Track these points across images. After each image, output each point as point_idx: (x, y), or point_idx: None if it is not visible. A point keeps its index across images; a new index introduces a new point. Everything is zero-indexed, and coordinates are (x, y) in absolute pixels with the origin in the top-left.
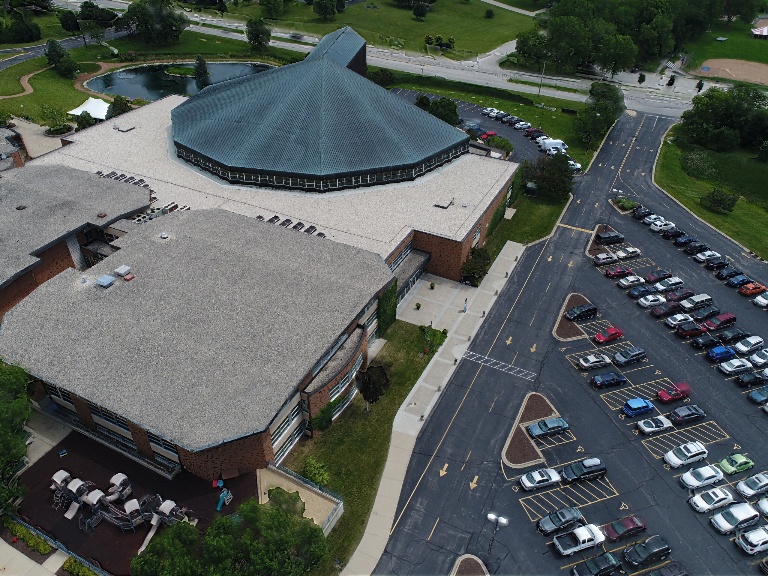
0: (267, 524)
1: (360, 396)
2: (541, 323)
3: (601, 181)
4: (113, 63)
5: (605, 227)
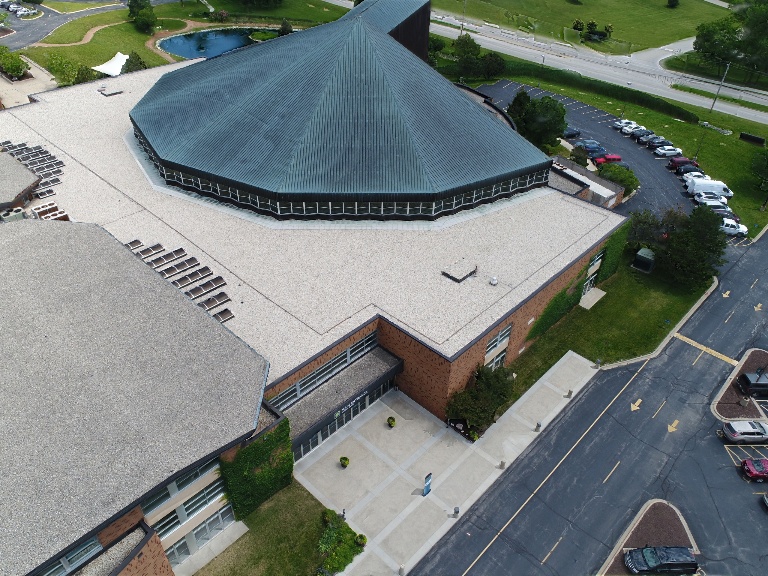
0: None
1: None
2: (567, 563)
3: None
4: (201, 22)
5: (760, 370)
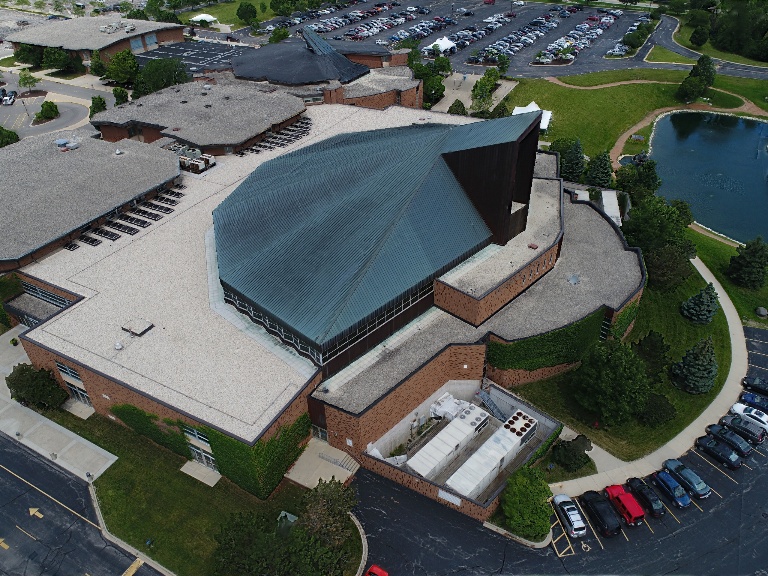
0: None
1: None
2: None
3: None
4: (761, 108)
5: None
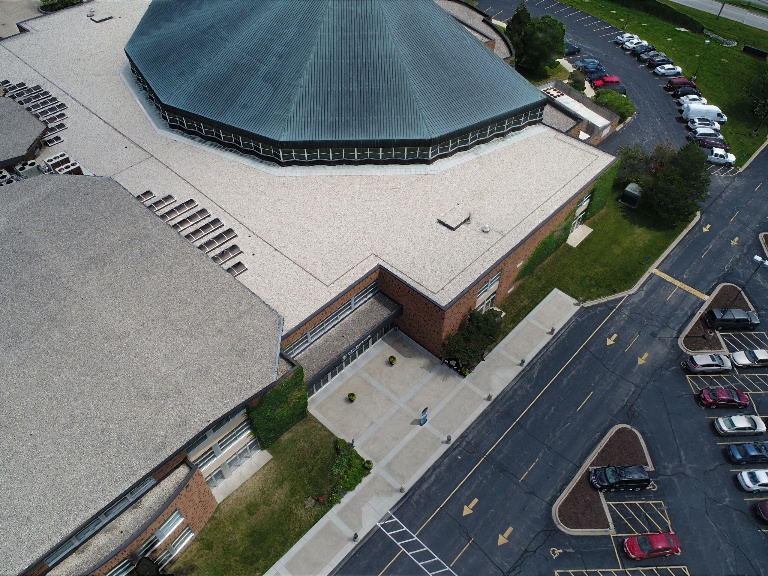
0: None
1: (175, 568)
2: (541, 480)
3: (760, 193)
4: None
5: (724, 309)
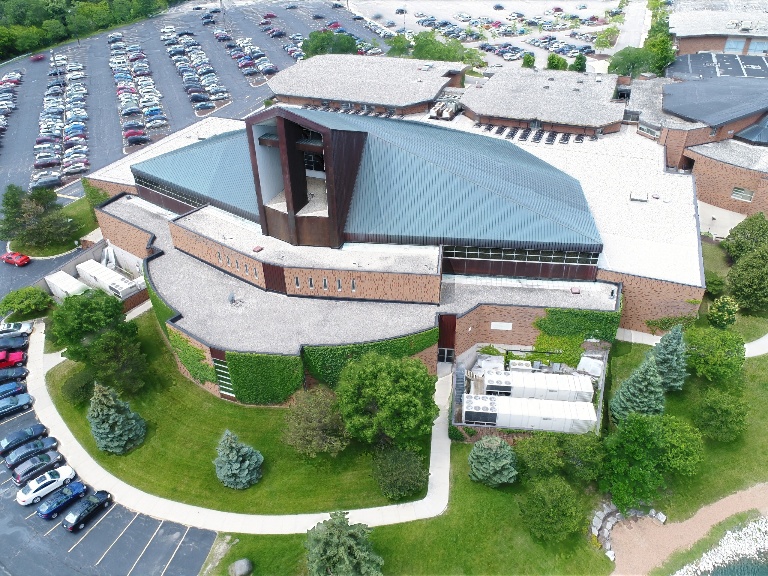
0: (316, 32)
1: None
2: None
3: None
4: None
5: None
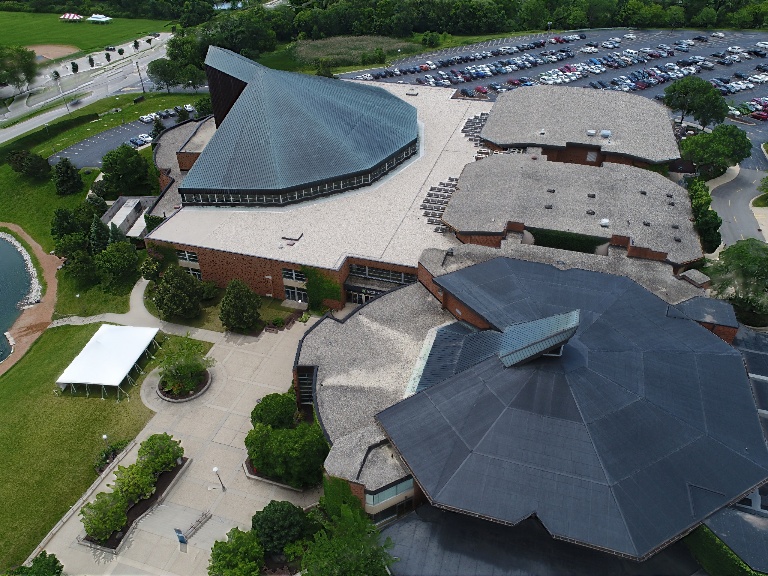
0: (690, 77)
1: None
2: None
3: None
4: None
5: None
